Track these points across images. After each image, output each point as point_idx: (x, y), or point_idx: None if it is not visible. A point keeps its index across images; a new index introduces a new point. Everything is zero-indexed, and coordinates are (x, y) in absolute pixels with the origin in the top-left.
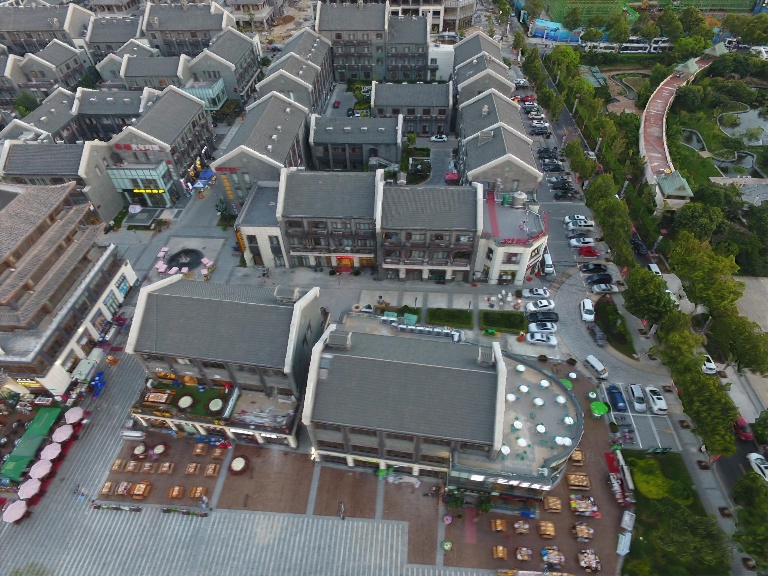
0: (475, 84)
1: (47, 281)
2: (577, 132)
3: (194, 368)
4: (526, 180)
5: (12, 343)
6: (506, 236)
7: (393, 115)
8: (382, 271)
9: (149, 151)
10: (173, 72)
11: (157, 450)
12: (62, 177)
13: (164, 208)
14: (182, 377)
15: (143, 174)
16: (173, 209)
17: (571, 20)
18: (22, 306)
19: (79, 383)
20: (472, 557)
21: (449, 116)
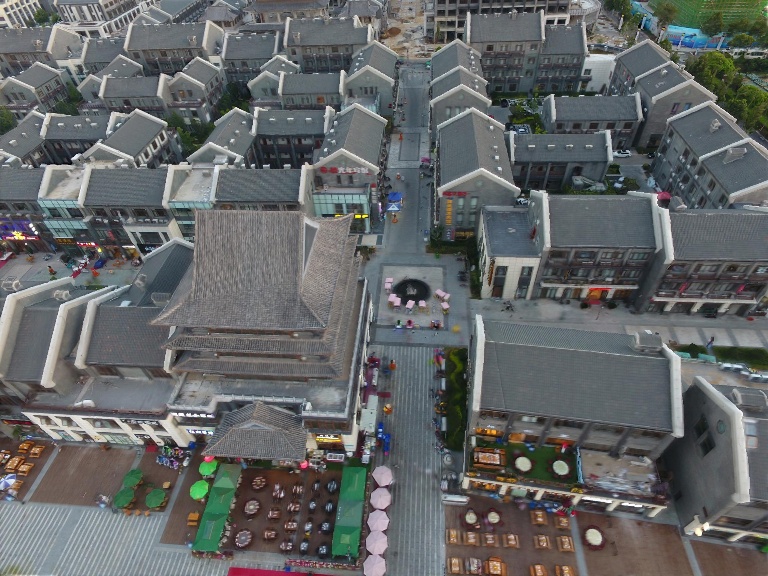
0: (673, 96)
1: None
2: (767, 144)
3: (540, 426)
4: None
5: (313, 395)
6: None
7: (573, 130)
8: (646, 304)
9: (356, 174)
10: (333, 89)
11: (492, 519)
12: (277, 204)
13: (362, 234)
14: None
15: (351, 199)
16: (372, 235)
17: (713, 26)
18: (330, 355)
19: (366, 436)
20: None
21: (635, 130)
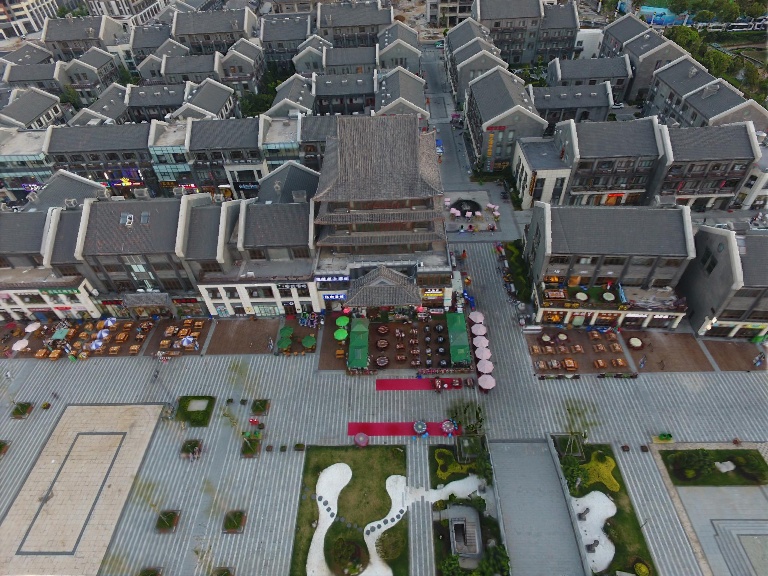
0: (656, 55)
1: None
2: None
3: (593, 266)
4: (759, 122)
5: (421, 260)
6: (765, 165)
7: None
8: (652, 203)
9: None
10: (370, 60)
11: (562, 337)
12: None
13: None
14: (568, 279)
15: None
16: None
17: (679, 5)
18: (434, 227)
19: (457, 297)
20: None
21: (626, 85)
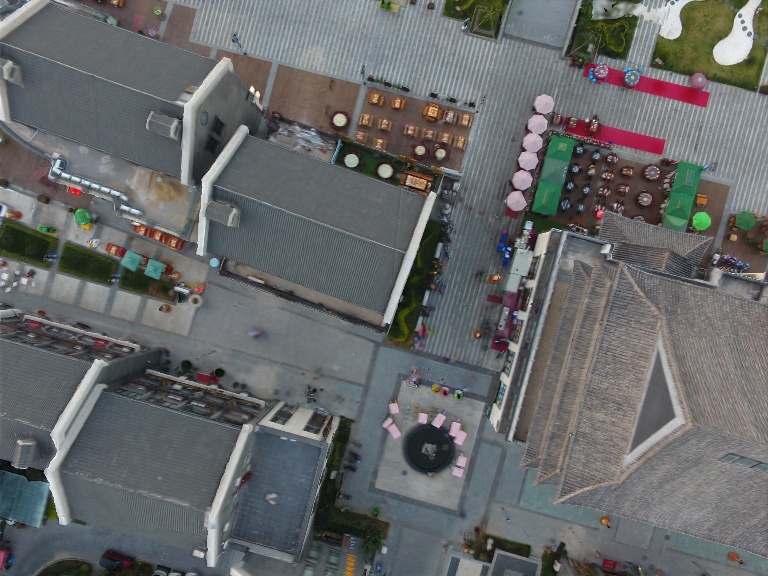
0: None
1: (571, 340)
2: None
3: None
4: None
5: None
6: None
7: None
8: None
9: None
10: None
11: (422, 149)
12: None
13: None
14: None
15: None
16: None
17: None
18: None
19: None
20: (142, 4)
21: None
